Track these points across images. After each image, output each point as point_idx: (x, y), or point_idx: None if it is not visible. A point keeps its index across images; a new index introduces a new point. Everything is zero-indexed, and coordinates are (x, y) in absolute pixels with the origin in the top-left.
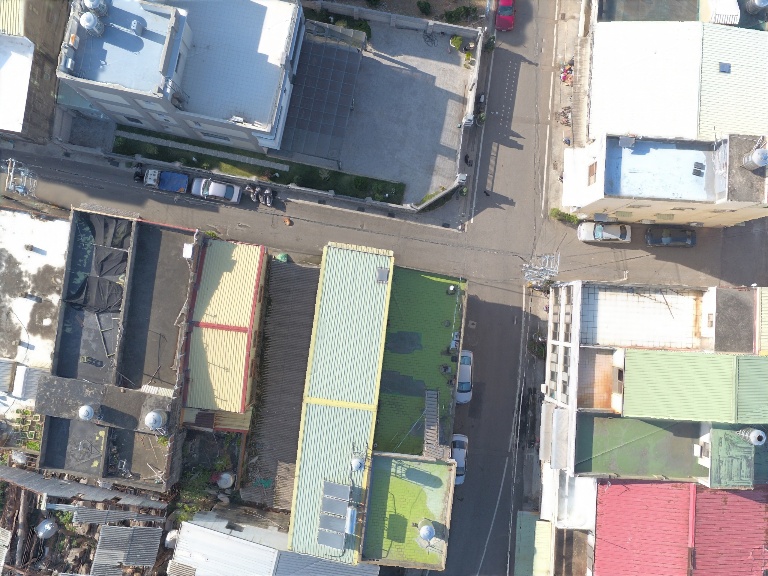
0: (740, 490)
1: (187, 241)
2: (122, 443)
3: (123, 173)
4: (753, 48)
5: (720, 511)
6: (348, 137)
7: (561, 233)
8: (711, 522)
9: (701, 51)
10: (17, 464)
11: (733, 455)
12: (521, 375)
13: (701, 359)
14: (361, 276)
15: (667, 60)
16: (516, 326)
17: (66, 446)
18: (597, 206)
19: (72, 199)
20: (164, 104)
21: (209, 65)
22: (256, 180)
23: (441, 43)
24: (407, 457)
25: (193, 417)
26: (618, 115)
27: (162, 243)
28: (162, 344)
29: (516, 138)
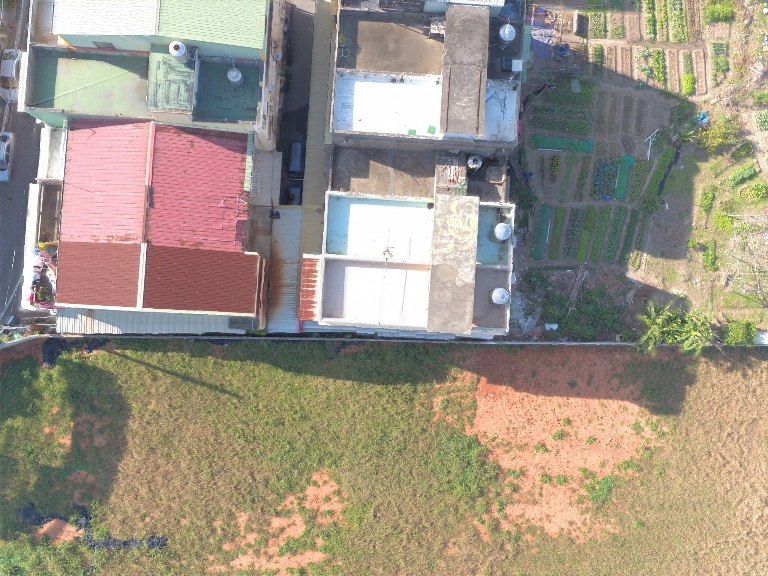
0: (210, 136)
1: None
2: None
3: None
4: None
5: (185, 154)
6: None
7: None
8: (173, 163)
9: None
10: None
11: (171, 79)
12: None
13: None
14: None
15: None
16: None
17: None
18: None
19: None
20: None
21: None
22: None
23: None
24: None
25: None
26: None
27: None
28: None
29: None
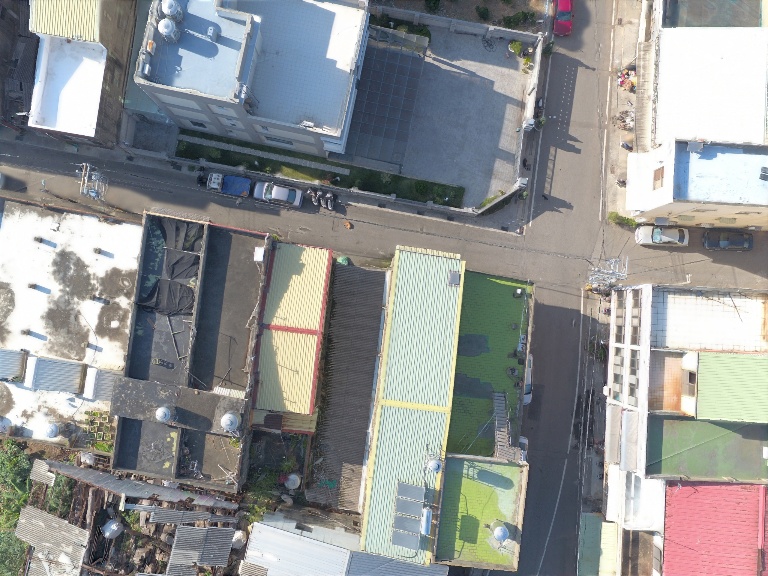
0: None
1: (257, 244)
2: (193, 444)
3: (185, 177)
4: None
5: None
6: (408, 141)
7: (619, 236)
8: None
9: (767, 57)
10: (85, 465)
11: None
12: (580, 377)
13: None
14: (433, 279)
15: (733, 65)
16: (574, 329)
17: (138, 447)
18: (662, 210)
19: (135, 202)
20: (238, 109)
21: (278, 70)
22: (319, 184)
23: (499, 48)
24: (480, 459)
25: (262, 419)
26: (685, 120)
27: (232, 246)
28: (232, 346)
29: (574, 142)
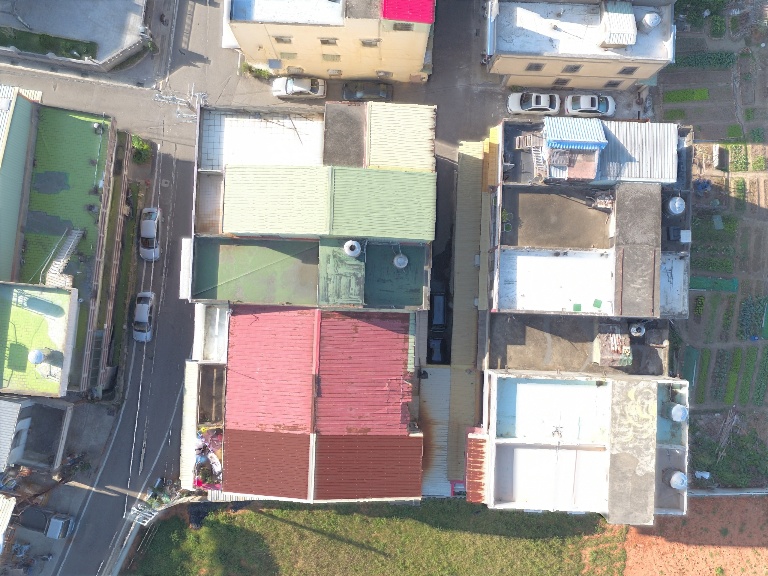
0: (374, 319)
1: None
2: None
3: None
4: None
5: (350, 339)
6: None
7: (257, 90)
8: (339, 350)
9: None
10: None
11: (341, 272)
12: None
13: (299, 171)
14: None
15: None
16: None
17: None
18: (250, 43)
19: None
20: None
21: None
22: None
23: None
24: (22, 284)
25: None
26: None
27: None
28: None
29: None
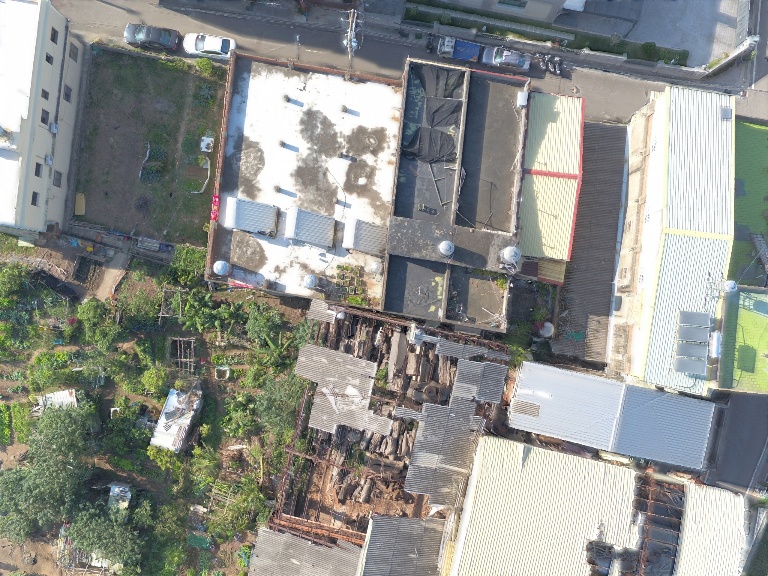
0: None
1: (514, 92)
2: (458, 288)
3: None
4: None
5: None
6: None
7: None
8: None
9: None
10: (335, 320)
11: None
12: None
13: None
14: (705, 114)
15: None
16: None
17: (404, 292)
18: None
19: (365, 70)
20: None
21: None
22: (552, 45)
23: None
24: (760, 287)
25: (519, 265)
26: None
27: (490, 94)
28: (493, 192)
29: None
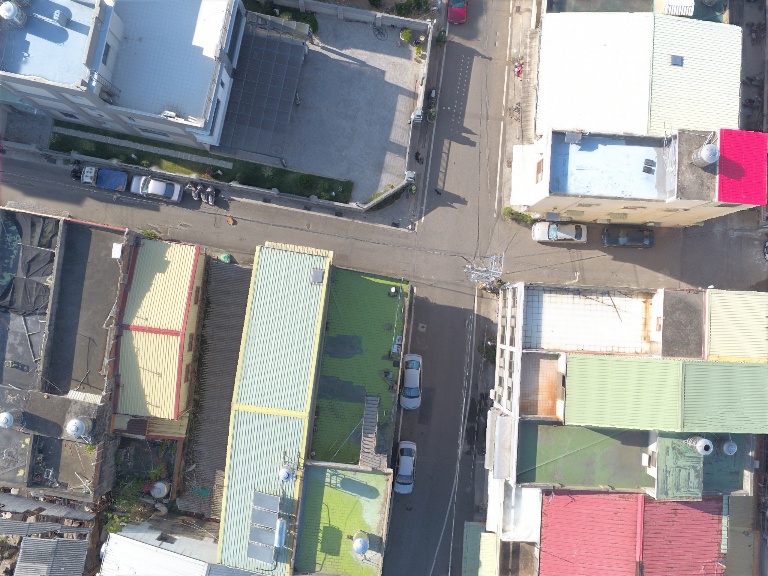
0: (691, 501)
1: (118, 241)
2: (49, 451)
3: (60, 170)
4: (707, 40)
5: (670, 523)
6: (294, 133)
7: None
8: (660, 535)
9: (652, 43)
10: None
11: (681, 465)
12: (473, 380)
13: (646, 365)
14: (295, 277)
15: (617, 53)
16: (468, 329)
17: None
18: (546, 205)
19: (7, 197)
20: (90, 98)
21: (141, 58)
22: (196, 178)
23: (391, 36)
24: (341, 467)
25: (125, 424)
26: (566, 110)
27: (92, 243)
28: (91, 348)
29: (469, 135)
